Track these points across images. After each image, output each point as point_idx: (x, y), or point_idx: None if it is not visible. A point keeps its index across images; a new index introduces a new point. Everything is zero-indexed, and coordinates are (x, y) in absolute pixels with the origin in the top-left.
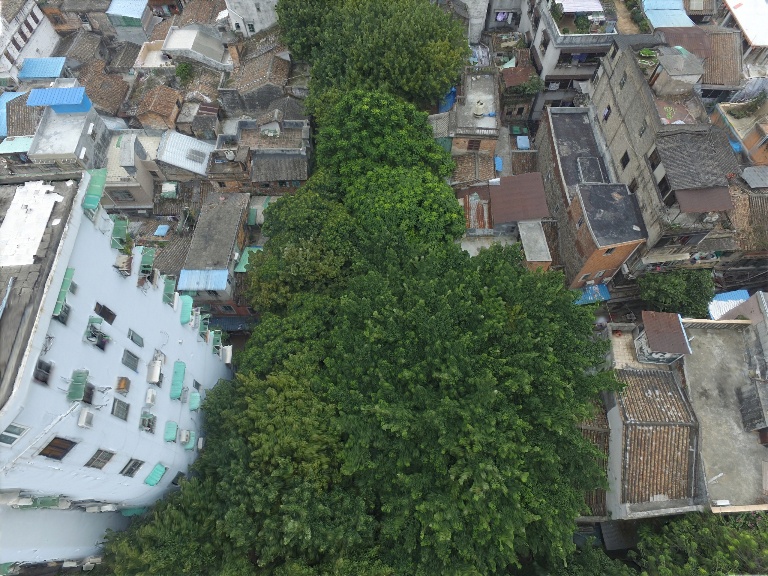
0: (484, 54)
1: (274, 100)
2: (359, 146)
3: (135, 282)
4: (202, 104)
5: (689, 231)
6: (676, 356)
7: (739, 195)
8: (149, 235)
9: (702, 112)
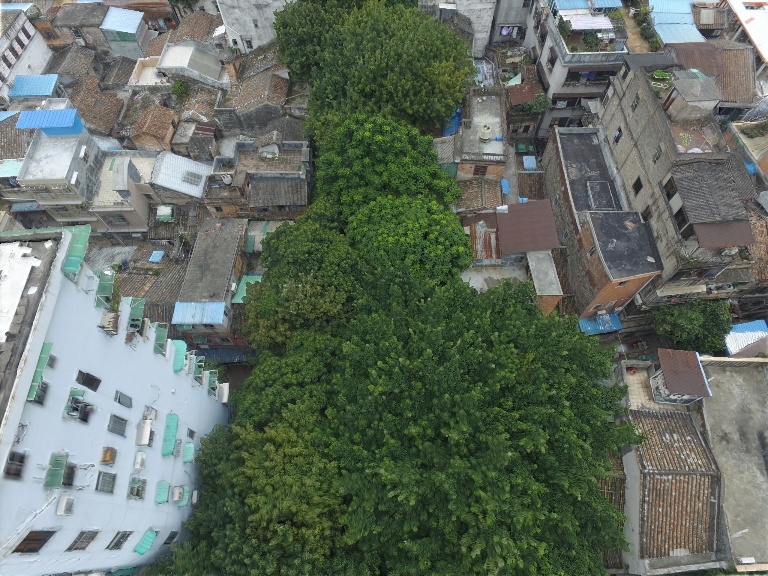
0: (488, 70)
1: (273, 120)
2: (361, 174)
3: (123, 338)
4: (198, 124)
5: (707, 265)
6: (695, 398)
7: (756, 221)
8: (143, 261)
9: (720, 139)
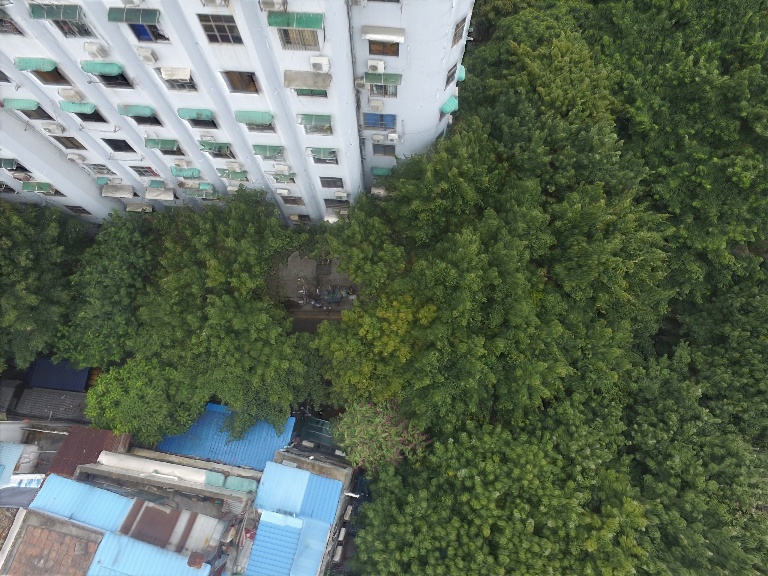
0: None
1: None
2: None
3: None
4: None
5: None
6: None
7: None
8: None
9: None
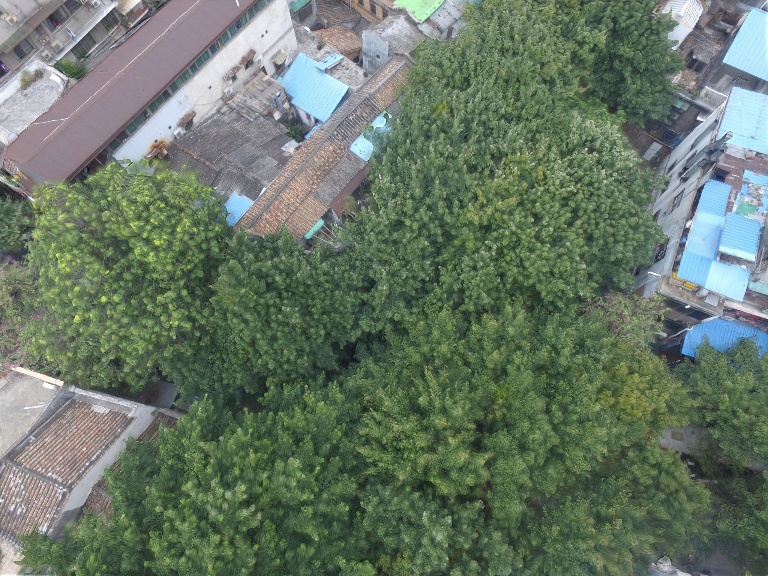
0: None
1: None
2: None
3: None
4: None
5: None
6: None
7: None
8: None
9: None
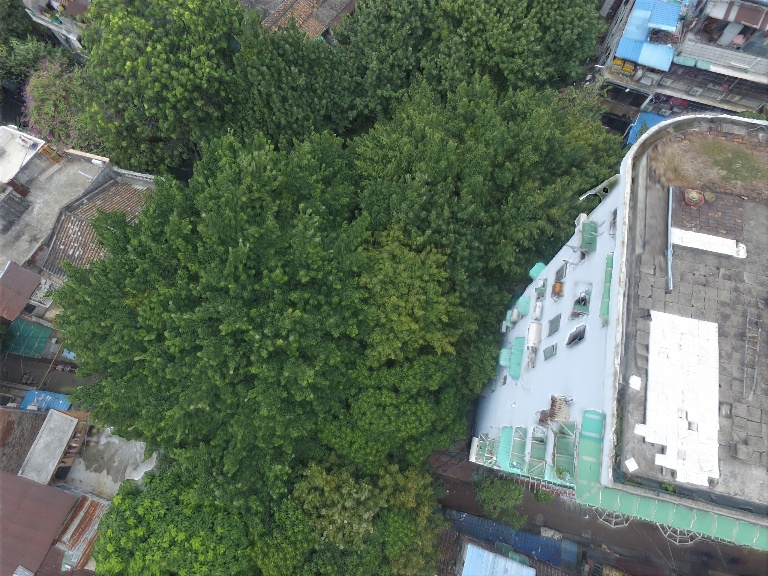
0: None
1: None
2: None
3: None
4: None
5: None
6: None
7: None
8: None
9: None
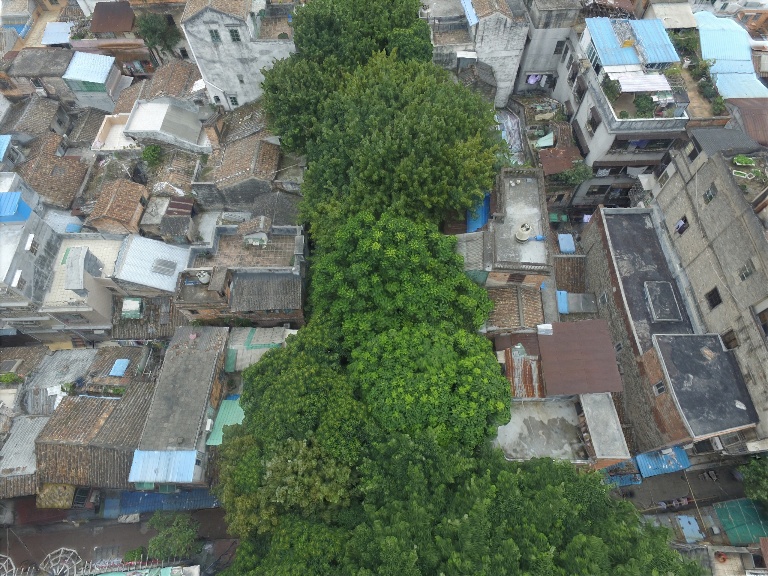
0: (513, 125)
1: (261, 194)
2: (368, 295)
3: None
4: (173, 199)
5: None
6: None
7: None
8: (103, 374)
9: None
